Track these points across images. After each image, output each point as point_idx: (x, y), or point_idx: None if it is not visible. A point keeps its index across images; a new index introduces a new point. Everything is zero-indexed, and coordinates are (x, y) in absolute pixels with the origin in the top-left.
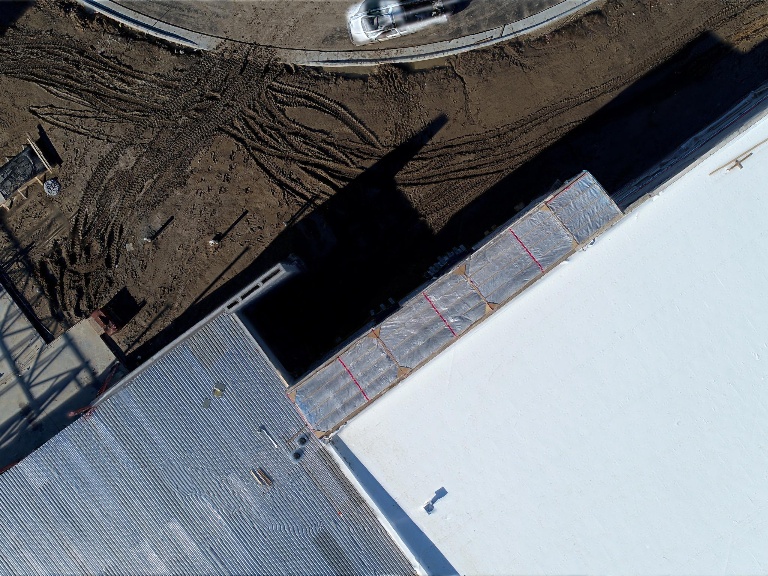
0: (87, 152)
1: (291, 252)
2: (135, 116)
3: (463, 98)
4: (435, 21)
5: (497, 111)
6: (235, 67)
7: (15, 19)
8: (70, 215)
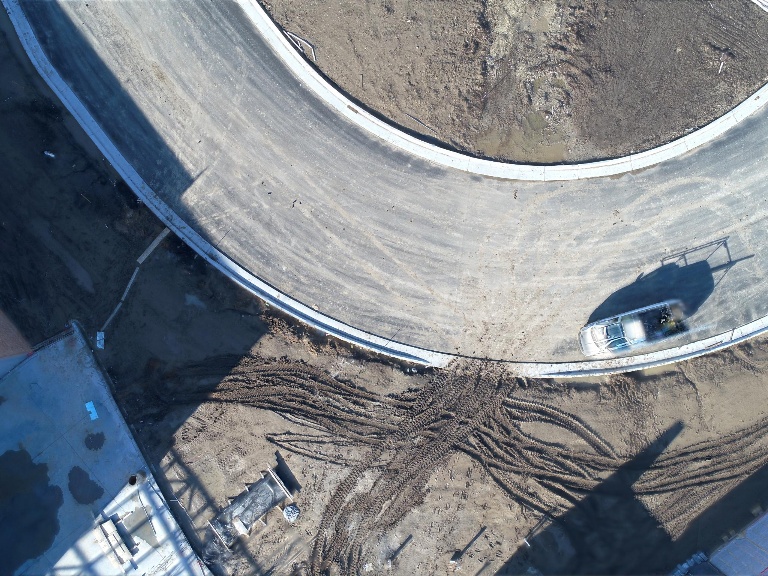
0: (326, 477)
1: (530, 566)
2: (372, 439)
3: (696, 405)
4: (664, 328)
5: (731, 417)
6: (469, 384)
7: (249, 347)
8: (309, 539)
